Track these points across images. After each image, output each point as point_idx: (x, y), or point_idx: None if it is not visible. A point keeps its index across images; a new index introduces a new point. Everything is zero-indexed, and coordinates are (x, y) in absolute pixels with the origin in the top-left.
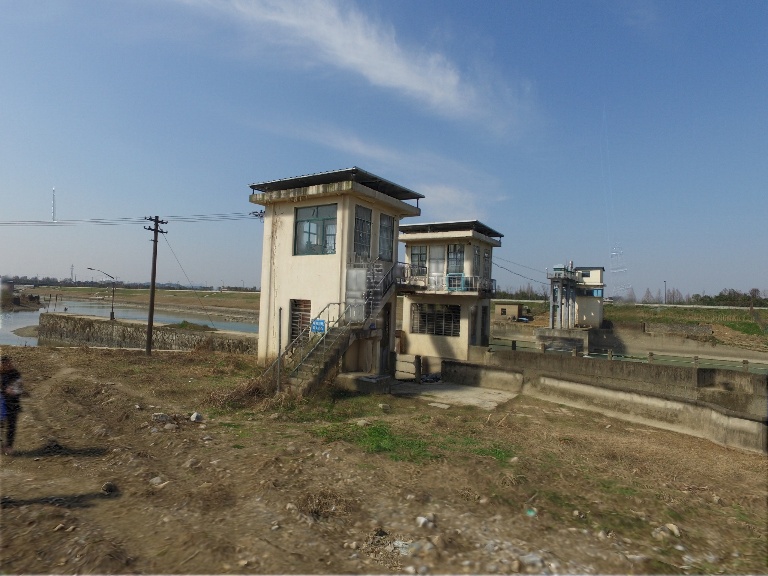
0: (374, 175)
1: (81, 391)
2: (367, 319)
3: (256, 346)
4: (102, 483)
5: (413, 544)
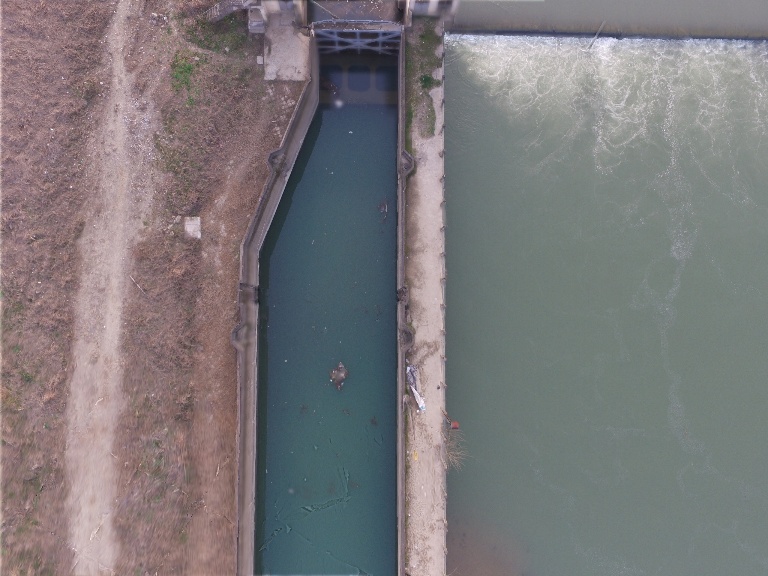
0: None
1: None
2: (245, 2)
3: None
4: (123, 46)
5: (137, 104)
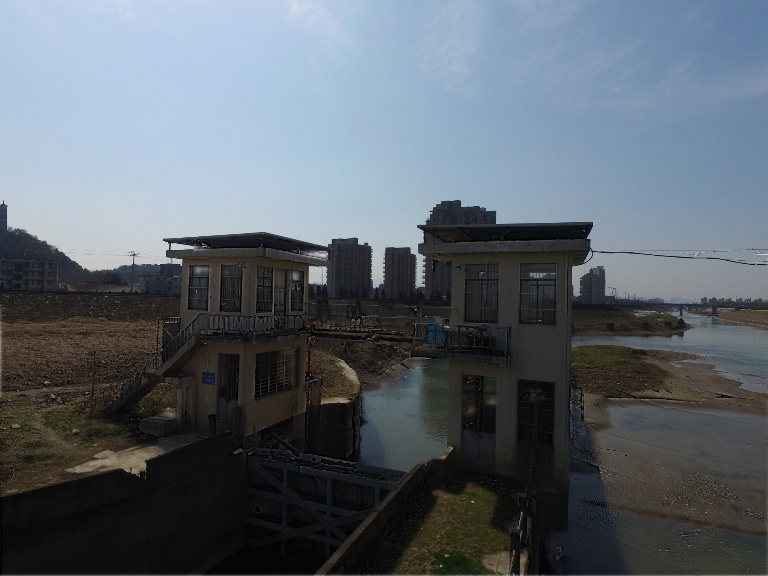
0: (183, 238)
1: None
2: (161, 366)
3: None
4: None
5: None
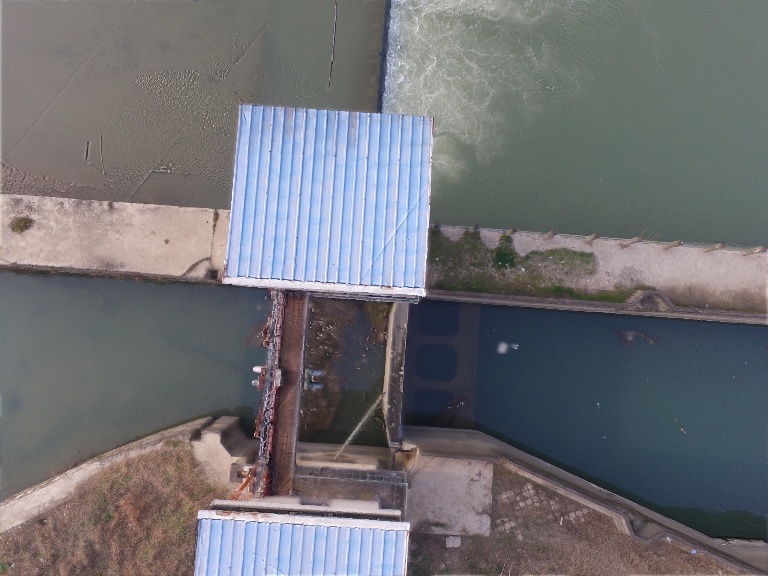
0: None
1: None
2: None
3: None
4: None
5: None
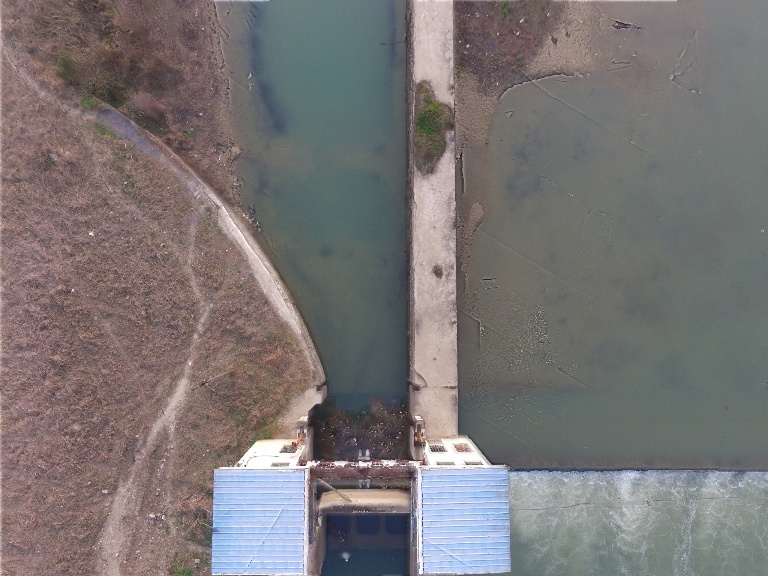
0: None
1: (162, 446)
2: None
3: (412, 263)
4: (118, 551)
5: None
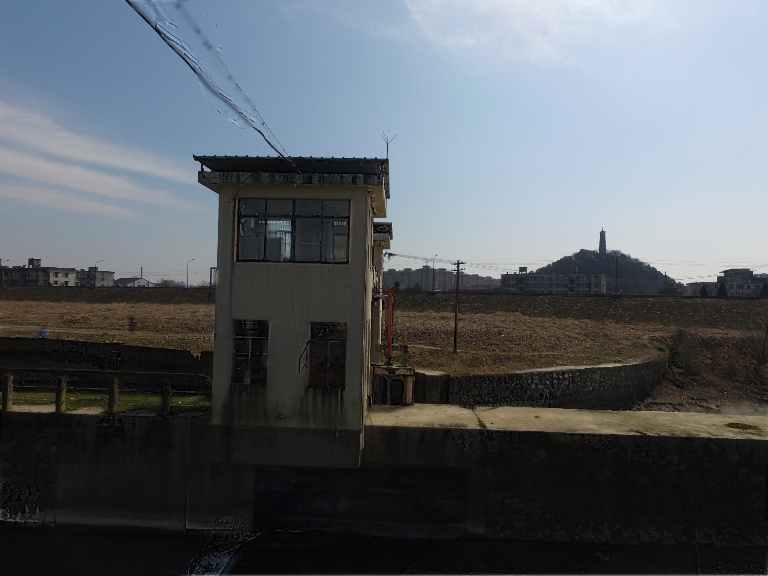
0: None
1: None
2: None
3: None
4: None
5: None
